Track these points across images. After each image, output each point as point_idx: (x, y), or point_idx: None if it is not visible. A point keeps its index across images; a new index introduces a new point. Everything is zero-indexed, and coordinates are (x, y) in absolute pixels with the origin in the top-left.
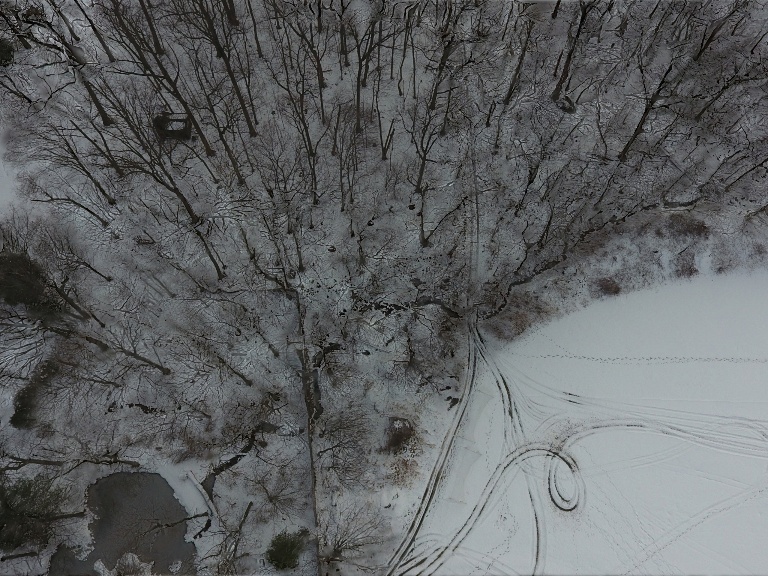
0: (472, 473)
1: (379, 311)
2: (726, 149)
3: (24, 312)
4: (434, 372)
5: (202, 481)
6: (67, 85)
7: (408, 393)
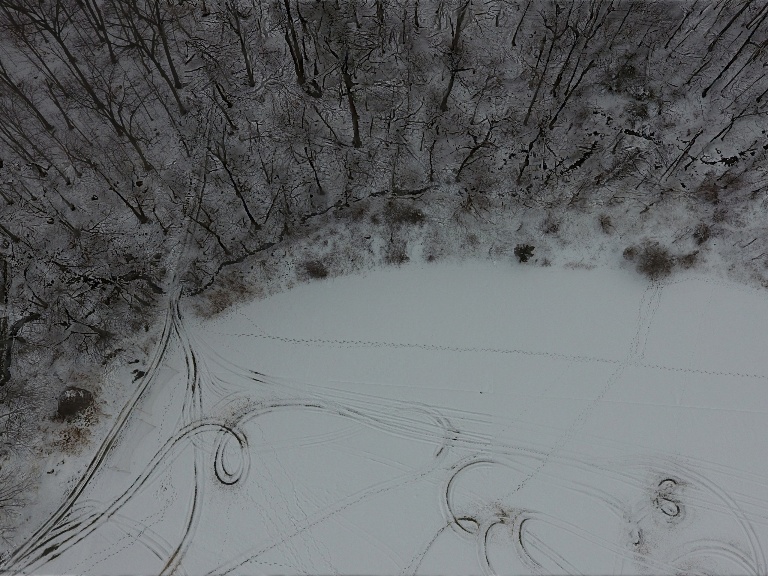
0: (143, 444)
1: (85, 284)
2: (467, 139)
3: None
4: (124, 345)
5: None
6: None
7: (94, 364)
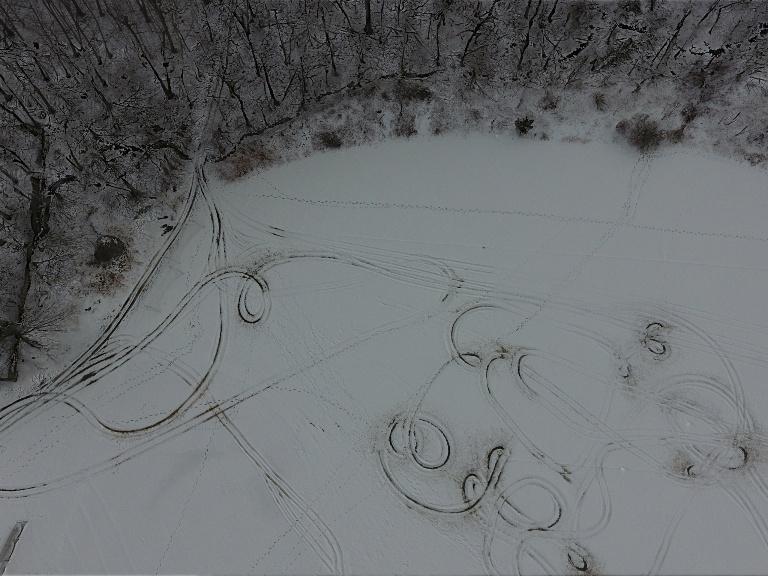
0: (172, 288)
1: (117, 151)
2: None
3: None
4: (154, 202)
5: None
6: None
7: (126, 218)
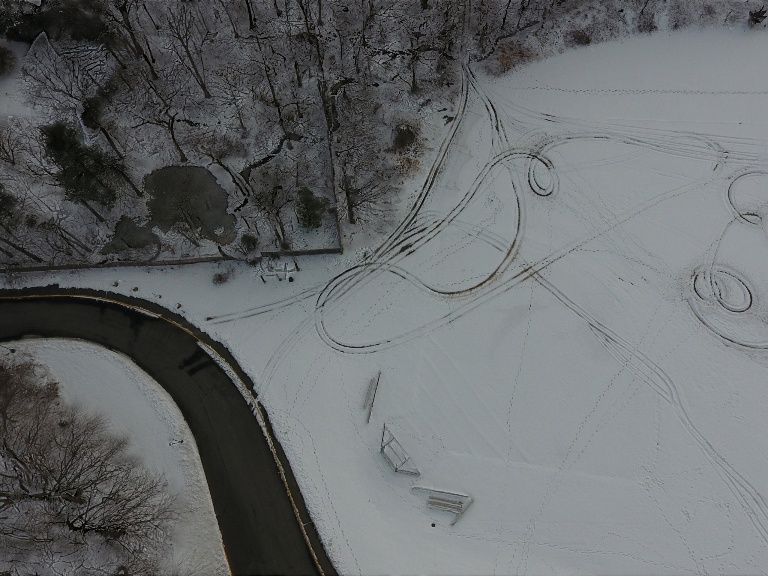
0: (465, 169)
1: (386, 55)
2: None
3: (88, 44)
4: (433, 96)
5: (240, 172)
6: None
7: (411, 111)
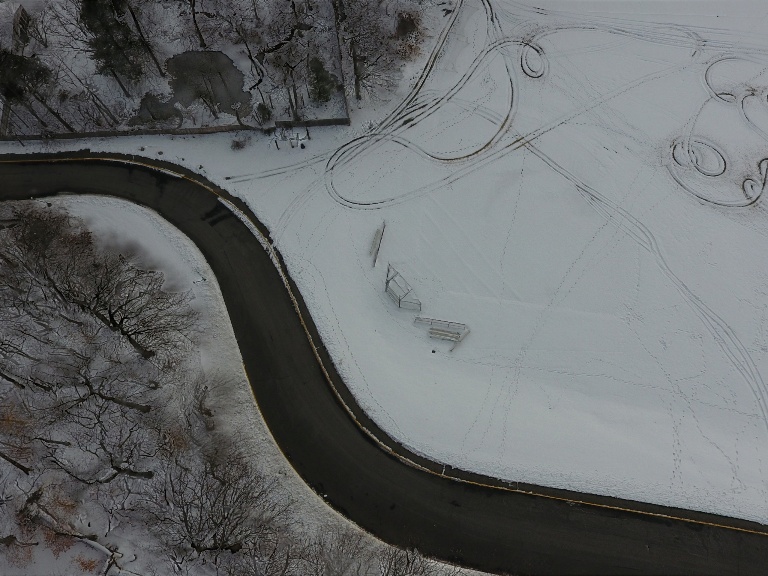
0: (462, 55)
1: None
2: None
3: None
4: None
5: (254, 56)
6: None
7: (413, 3)
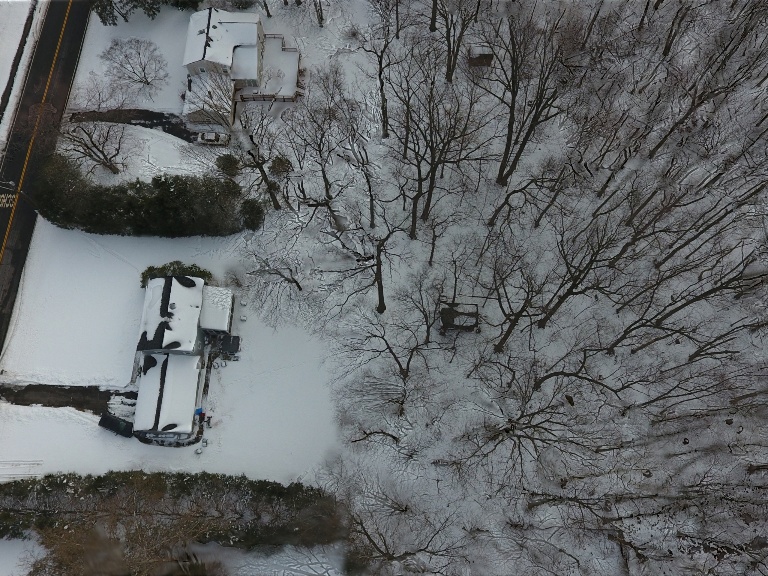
0: None
1: (710, 555)
2: None
3: (324, 557)
4: None
5: None
6: (366, 288)
7: None
